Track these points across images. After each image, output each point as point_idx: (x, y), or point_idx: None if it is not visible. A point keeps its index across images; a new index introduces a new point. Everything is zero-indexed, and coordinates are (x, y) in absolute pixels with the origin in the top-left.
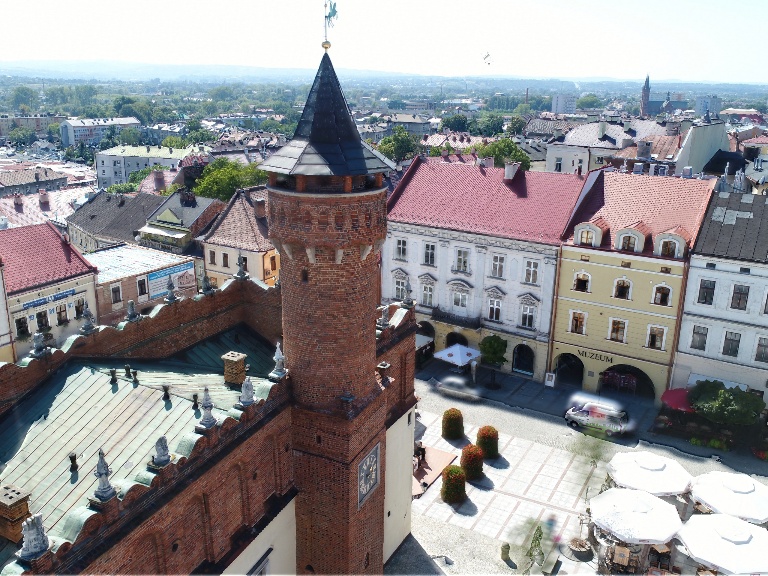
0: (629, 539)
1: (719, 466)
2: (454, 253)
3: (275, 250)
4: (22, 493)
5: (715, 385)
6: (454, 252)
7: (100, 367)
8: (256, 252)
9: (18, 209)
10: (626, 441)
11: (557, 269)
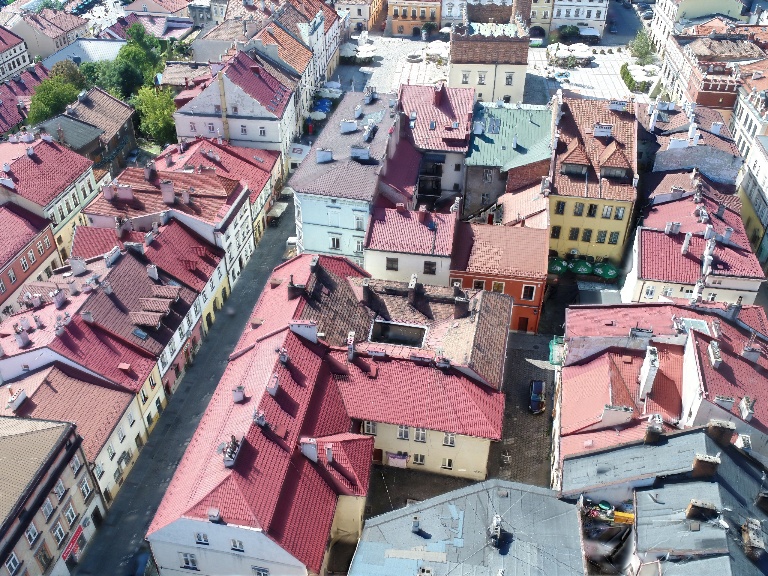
0: (562, 57)
1: None
2: None
3: (388, 2)
4: None
5: (565, 26)
6: None
7: None
8: (368, 5)
9: (159, 0)
10: (544, 47)
11: None
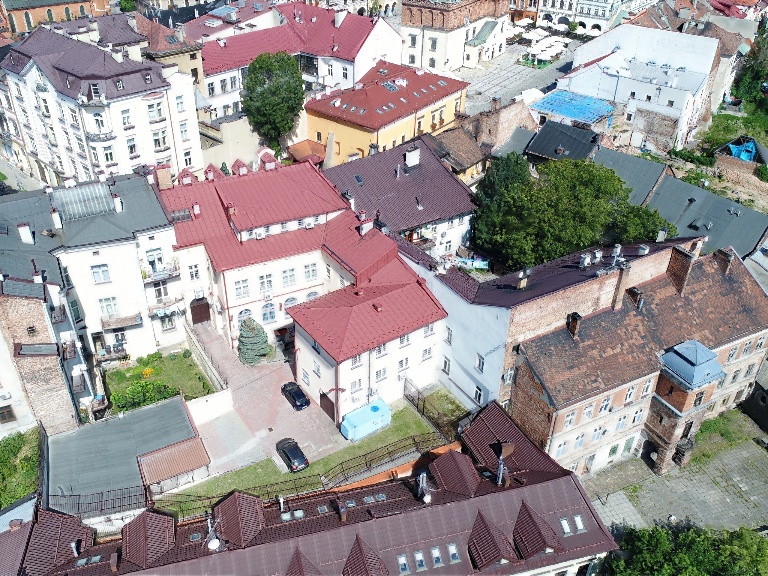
0: None
1: None
2: None
3: None
4: None
5: None
6: None
7: None
8: None
9: None
10: None
11: None
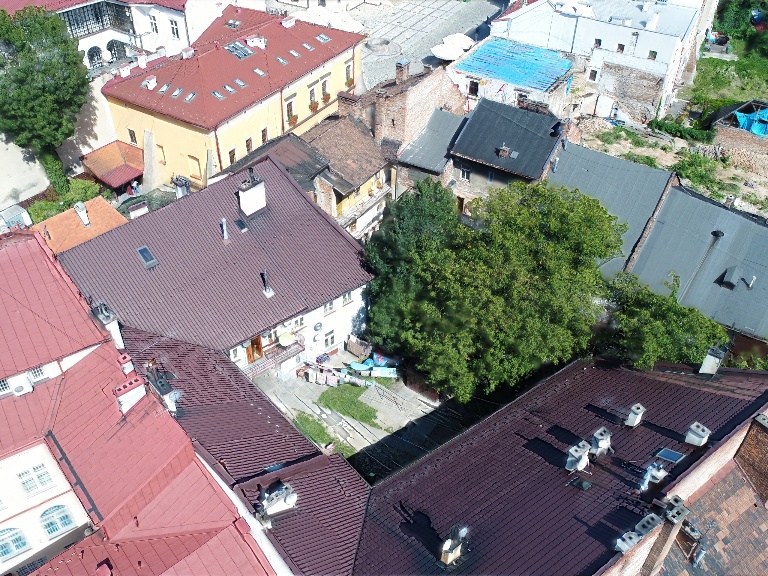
0: None
1: None
2: None
3: None
4: None
5: None
6: None
7: None
8: None
9: None
10: None
11: None
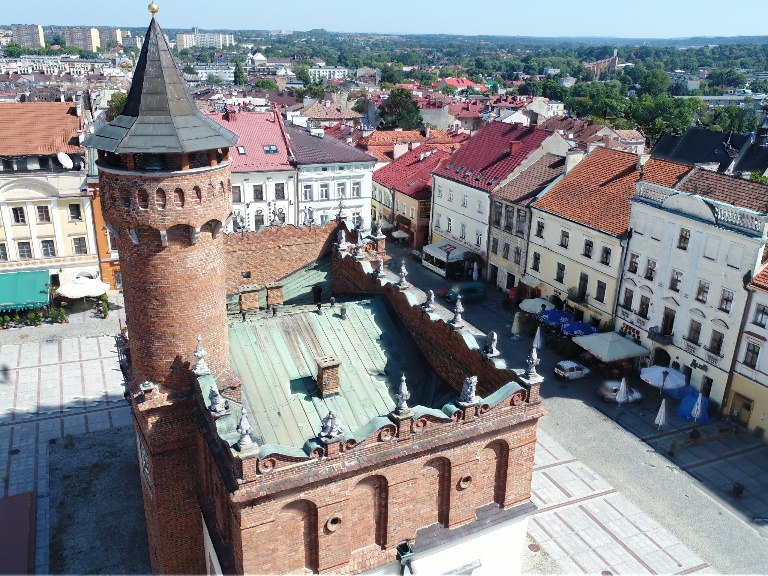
0: None
1: None
2: None
3: None
4: (243, 288)
5: None
6: None
7: (374, 310)
8: None
9: None
10: None
11: None
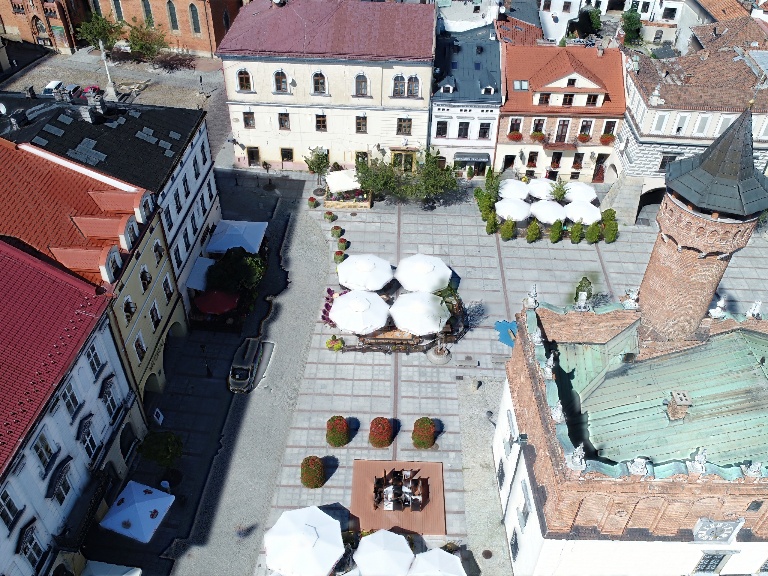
0: None
1: (284, 296)
2: (35, 457)
3: None
4: None
5: None
6: (34, 456)
7: None
8: None
9: None
10: (265, 350)
11: (114, 324)
